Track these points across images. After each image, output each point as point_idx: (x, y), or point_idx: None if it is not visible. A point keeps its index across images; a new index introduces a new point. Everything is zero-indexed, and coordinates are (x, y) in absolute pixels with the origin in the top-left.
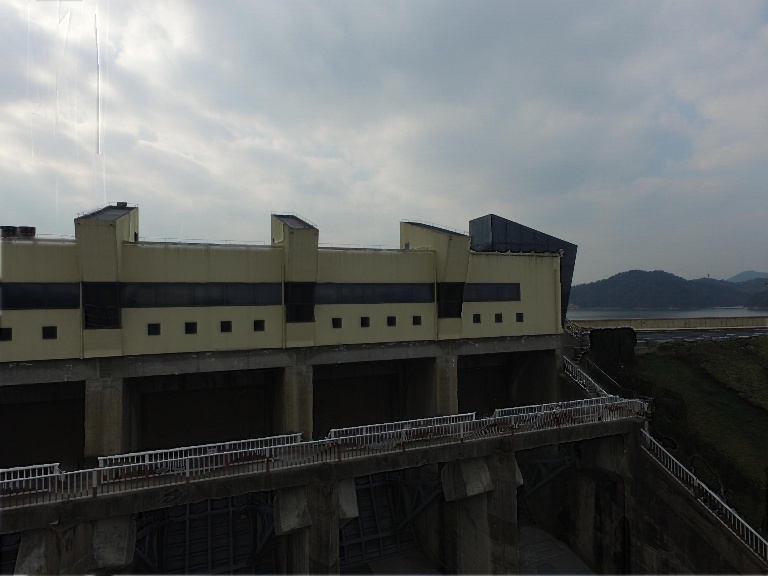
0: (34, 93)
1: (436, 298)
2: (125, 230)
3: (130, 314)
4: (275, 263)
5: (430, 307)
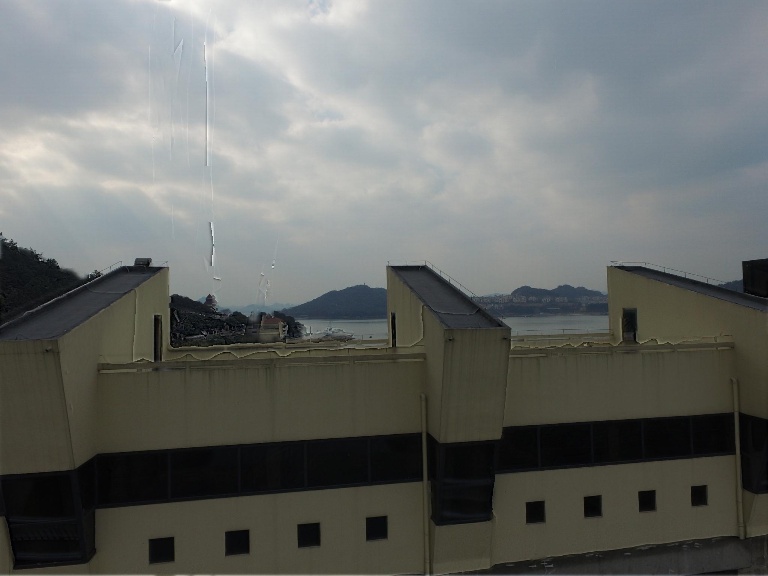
0: (154, 119)
1: (739, 446)
2: (112, 335)
3: (113, 520)
4: (407, 391)
5: (725, 465)
